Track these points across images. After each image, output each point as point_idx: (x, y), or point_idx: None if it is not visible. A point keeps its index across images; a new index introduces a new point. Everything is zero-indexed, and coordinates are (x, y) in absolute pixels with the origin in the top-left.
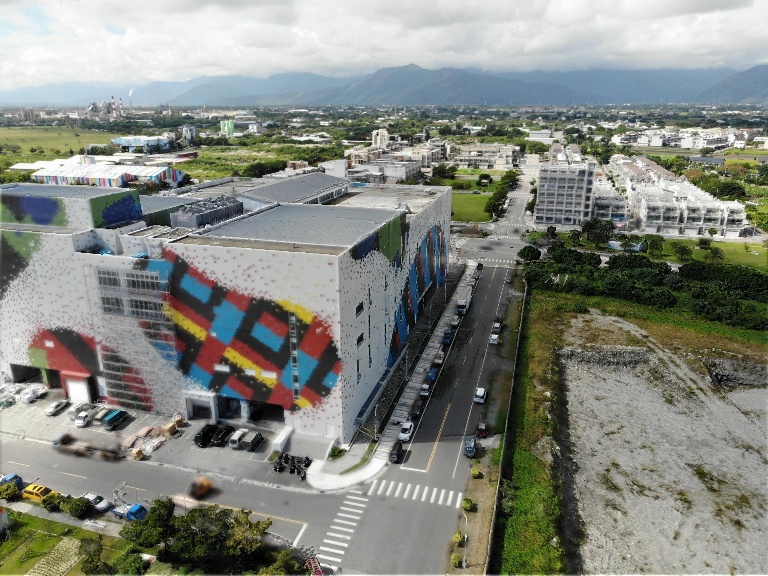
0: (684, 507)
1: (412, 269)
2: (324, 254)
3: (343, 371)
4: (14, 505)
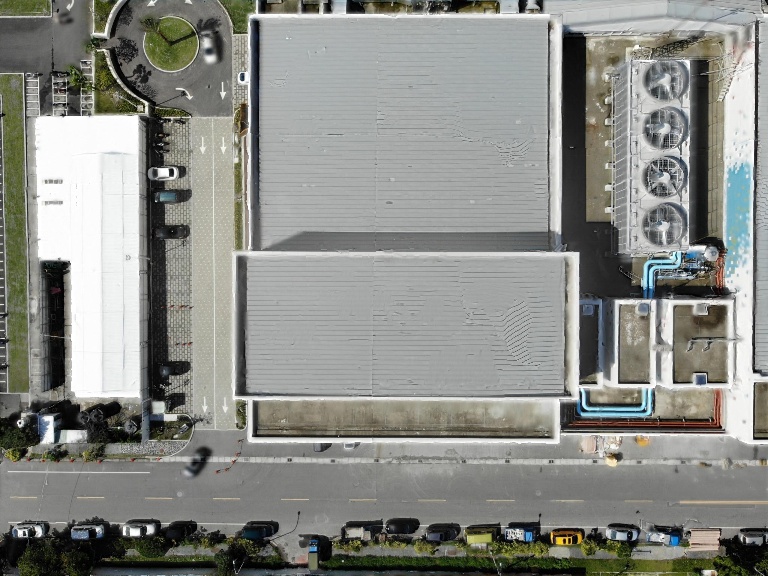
0: None
1: None
2: None
3: None
4: (552, 552)
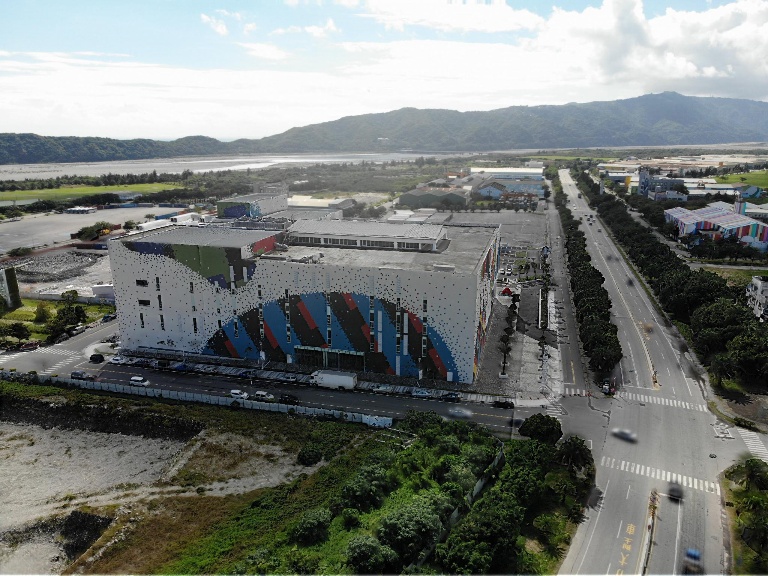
0: None
1: (272, 307)
2: None
3: (120, 306)
4: None
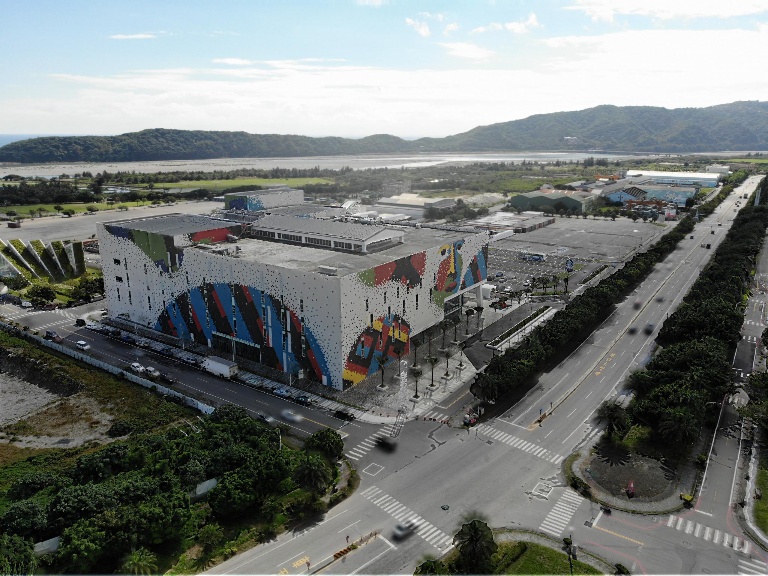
0: None
1: (196, 293)
2: None
3: None
4: None
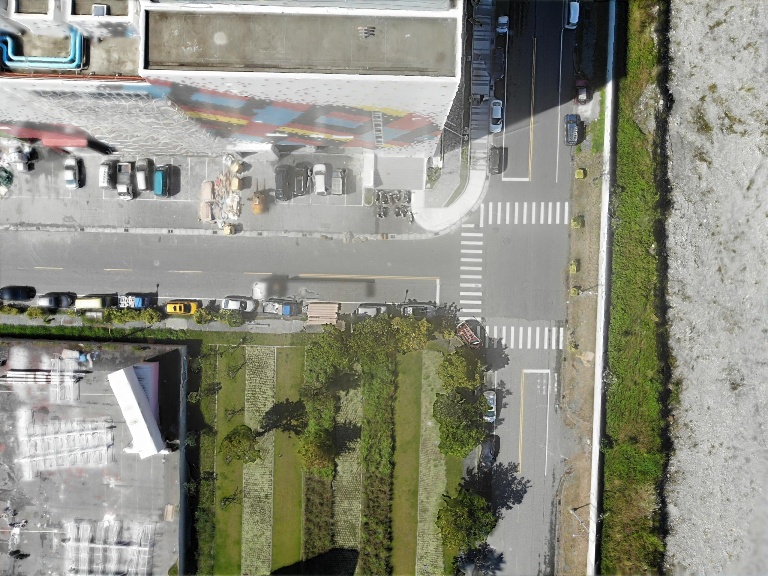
0: (767, 144)
1: None
2: (435, 78)
3: None
4: (168, 323)
